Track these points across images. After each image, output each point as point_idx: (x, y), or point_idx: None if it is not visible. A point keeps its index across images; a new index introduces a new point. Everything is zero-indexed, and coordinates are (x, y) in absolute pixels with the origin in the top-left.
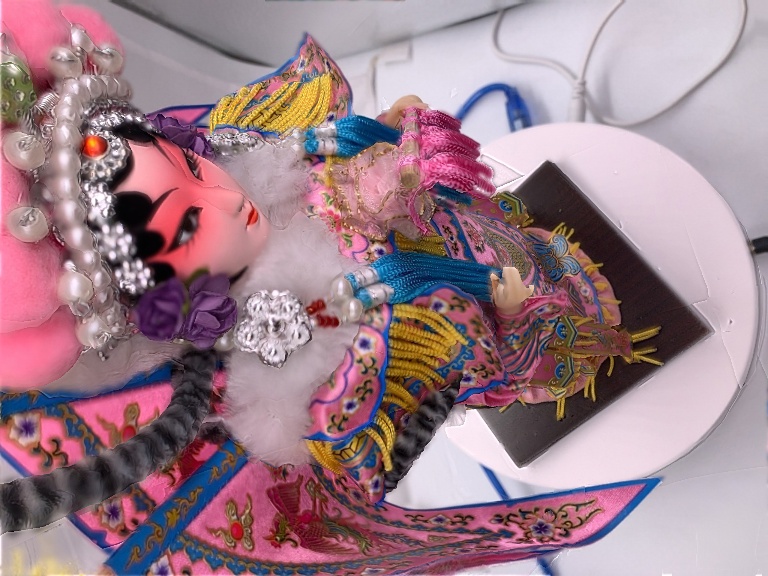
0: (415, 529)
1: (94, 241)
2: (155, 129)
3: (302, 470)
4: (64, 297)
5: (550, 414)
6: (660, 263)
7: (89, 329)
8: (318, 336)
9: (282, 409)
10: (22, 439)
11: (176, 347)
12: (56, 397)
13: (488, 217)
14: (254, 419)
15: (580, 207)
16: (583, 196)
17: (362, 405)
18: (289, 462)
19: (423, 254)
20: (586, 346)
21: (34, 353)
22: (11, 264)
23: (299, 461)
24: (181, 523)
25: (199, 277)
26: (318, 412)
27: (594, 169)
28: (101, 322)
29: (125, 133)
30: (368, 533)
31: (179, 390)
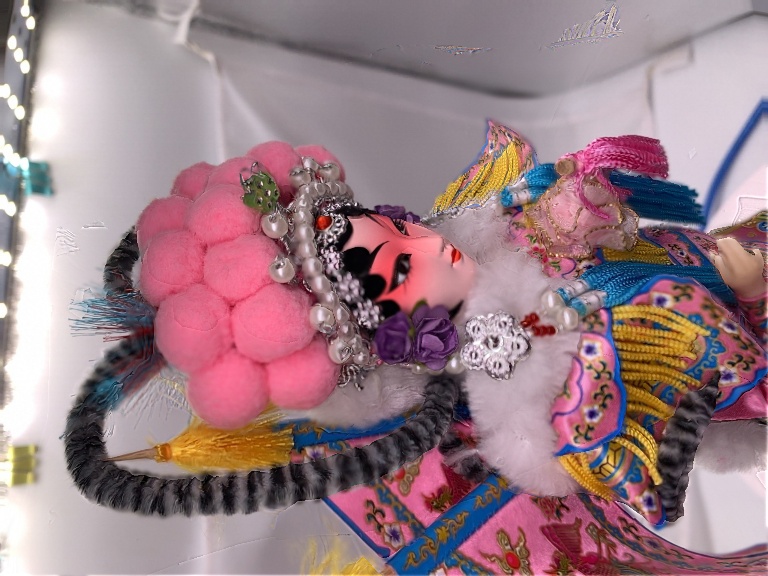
0: (729, 572)
1: (332, 287)
2: None
3: (579, 513)
4: (314, 323)
5: None
6: None
7: (336, 348)
8: (538, 346)
9: (523, 423)
10: None
11: (418, 379)
12: (334, 433)
13: (744, 241)
14: (502, 442)
15: None
16: None
17: (605, 413)
18: (552, 490)
19: (639, 263)
20: None
21: (303, 373)
22: (275, 301)
23: (562, 488)
24: (452, 542)
25: (419, 308)
26: (561, 425)
27: None
28: (344, 343)
29: (345, 213)
30: (669, 575)
31: (422, 408)
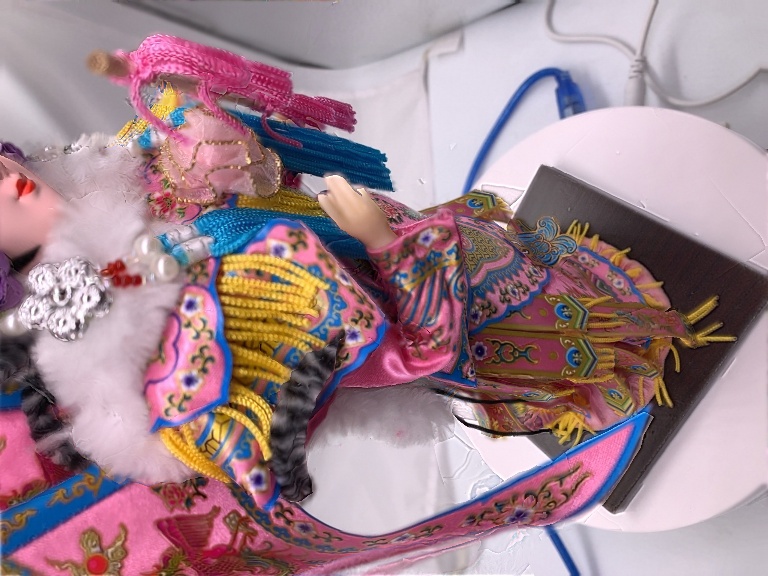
0: None
1: None
2: None
3: (219, 501)
4: None
5: None
6: (695, 228)
7: None
8: (121, 300)
9: (102, 395)
10: None
11: None
12: None
13: None
14: (89, 420)
15: (588, 198)
16: (588, 186)
17: (207, 379)
18: (162, 476)
19: None
20: (610, 328)
21: None
22: None
23: (173, 472)
24: None
25: None
26: (153, 395)
27: (594, 157)
28: None
29: None
30: (300, 563)
31: None
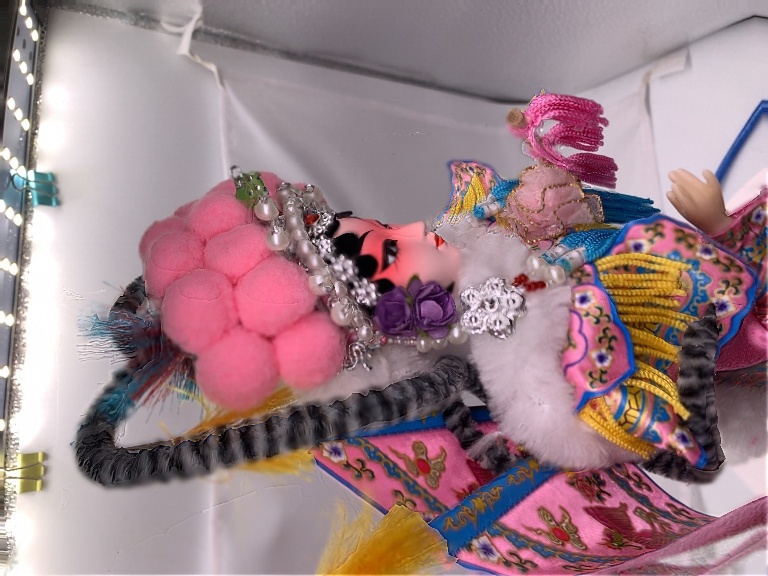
0: None
1: None
2: None
3: (622, 499)
4: (313, 286)
5: None
6: None
7: (338, 309)
8: (533, 302)
9: (536, 379)
10: (333, 458)
11: (425, 360)
12: None
13: None
14: (521, 409)
15: None
16: None
17: (614, 355)
18: (585, 459)
19: None
20: None
21: (309, 339)
22: (274, 267)
23: (594, 453)
24: (491, 513)
25: (412, 283)
26: (574, 375)
27: None
28: None
29: None
30: None
31: None
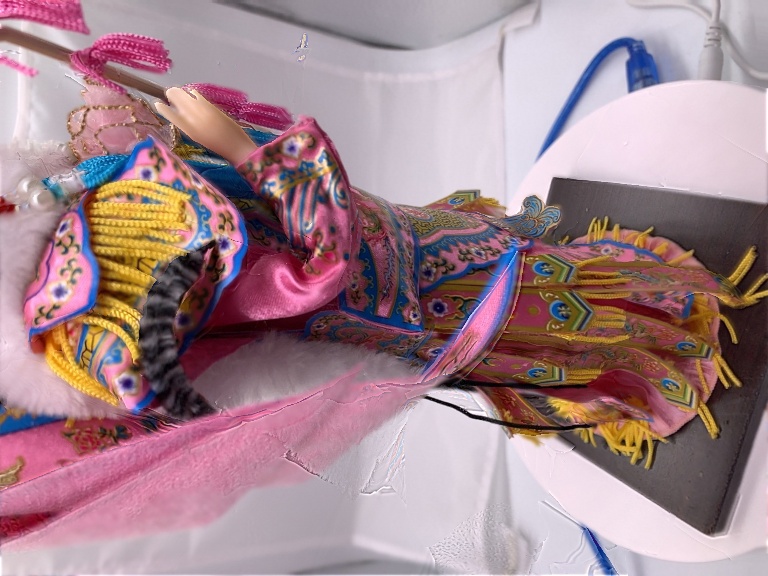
0: None
1: None
2: None
3: None
4: None
5: (701, 436)
6: (717, 187)
7: None
8: None
9: None
10: None
11: None
12: None
13: None
14: None
15: (602, 193)
16: (600, 182)
17: (76, 290)
18: (57, 406)
19: None
20: (610, 285)
21: None
22: None
23: (65, 400)
24: None
25: None
26: (28, 310)
27: (603, 155)
28: None
29: None
30: None
31: None
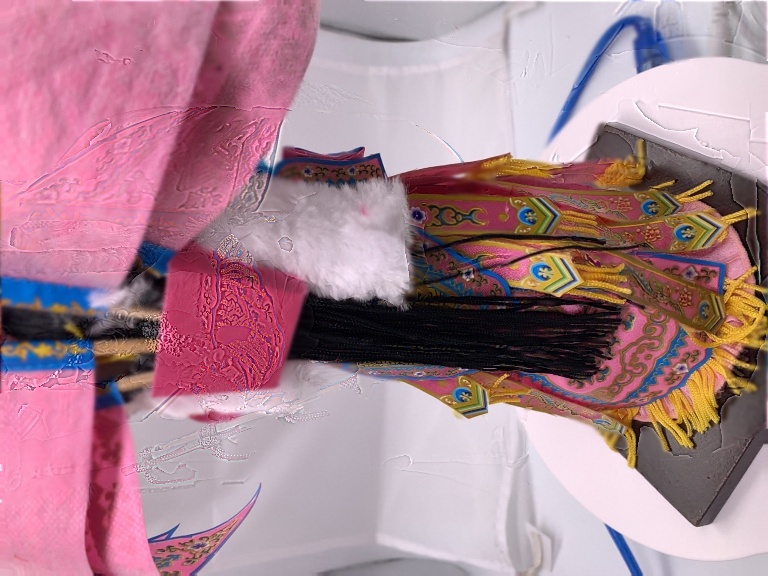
0: None
1: None
2: (81, 357)
3: None
4: None
5: None
6: None
7: None
8: None
9: None
10: None
11: None
12: None
13: None
14: None
15: None
16: None
17: None
18: None
19: None
20: None
21: None
22: None
23: None
24: None
25: None
26: None
27: None
28: None
29: None
30: None
31: None
